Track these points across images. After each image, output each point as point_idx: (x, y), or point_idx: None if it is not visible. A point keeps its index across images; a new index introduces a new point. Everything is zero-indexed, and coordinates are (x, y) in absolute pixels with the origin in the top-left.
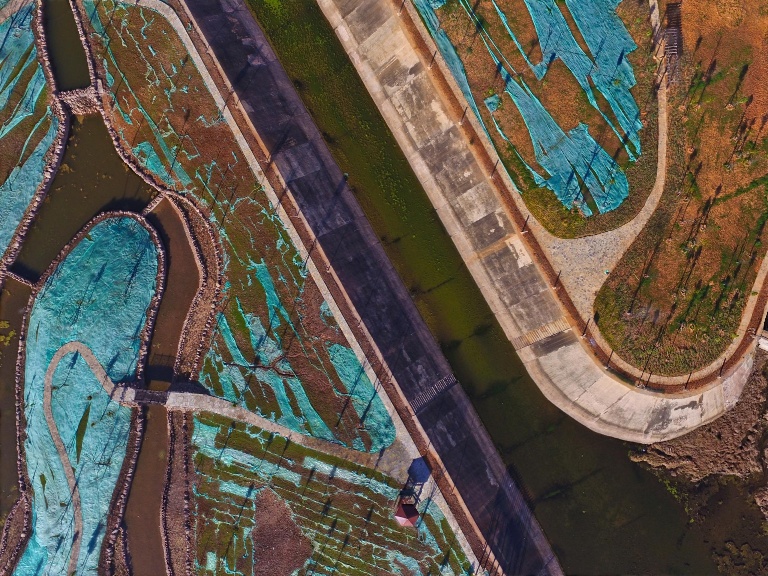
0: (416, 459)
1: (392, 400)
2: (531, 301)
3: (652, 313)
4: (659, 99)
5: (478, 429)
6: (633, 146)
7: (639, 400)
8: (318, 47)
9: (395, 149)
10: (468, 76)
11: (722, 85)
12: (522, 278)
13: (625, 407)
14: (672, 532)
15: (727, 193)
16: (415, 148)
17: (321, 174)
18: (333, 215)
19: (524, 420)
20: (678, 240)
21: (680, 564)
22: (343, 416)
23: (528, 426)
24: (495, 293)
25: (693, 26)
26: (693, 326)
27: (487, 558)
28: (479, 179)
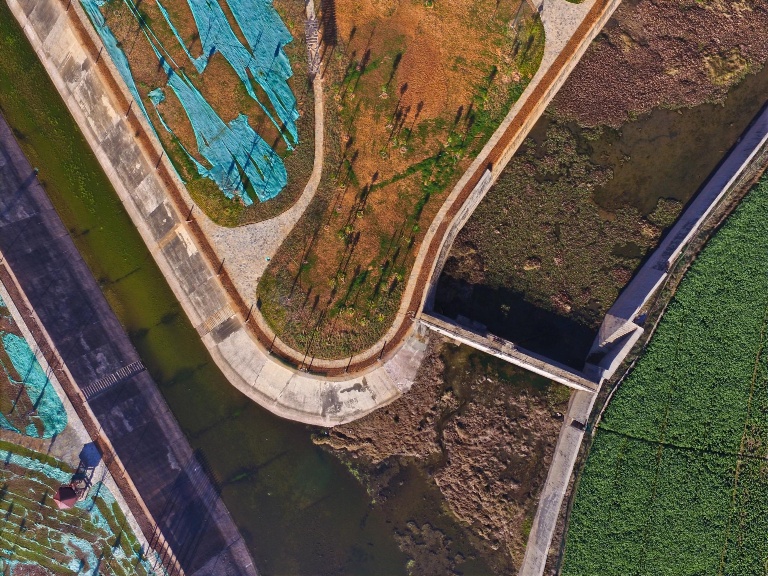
0: (87, 444)
1: (64, 387)
2: (203, 289)
3: (312, 298)
4: (315, 89)
5: (164, 415)
6: (290, 135)
7: (304, 383)
8: (8, 46)
9: (83, 143)
10: (132, 71)
11: (376, 74)
12: (193, 266)
13: (295, 391)
14: (355, 513)
15: (384, 179)
16: (98, 142)
17: (5, 169)
18: (14, 208)
19: (210, 405)
20: (336, 226)
21: (364, 544)
22: (17, 403)
23: (214, 411)
24: (177, 282)
25: (347, 17)
26: (352, 310)
27: (157, 539)
28: (147, 171)
